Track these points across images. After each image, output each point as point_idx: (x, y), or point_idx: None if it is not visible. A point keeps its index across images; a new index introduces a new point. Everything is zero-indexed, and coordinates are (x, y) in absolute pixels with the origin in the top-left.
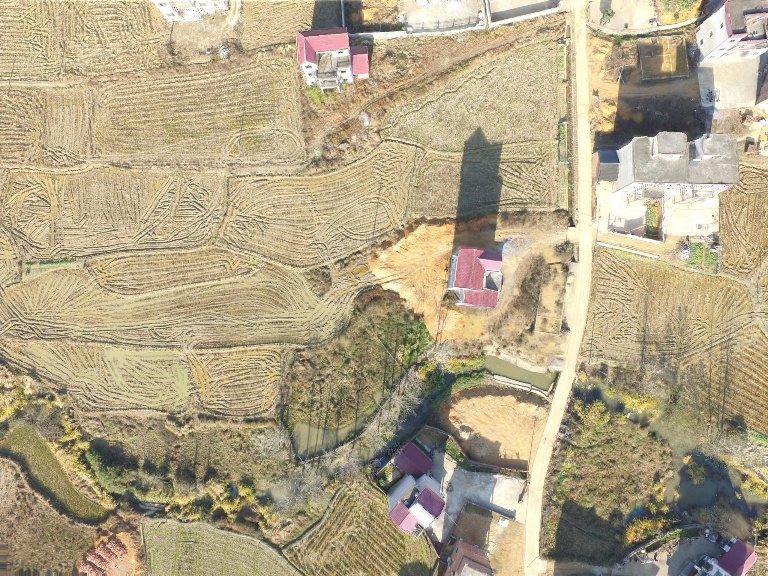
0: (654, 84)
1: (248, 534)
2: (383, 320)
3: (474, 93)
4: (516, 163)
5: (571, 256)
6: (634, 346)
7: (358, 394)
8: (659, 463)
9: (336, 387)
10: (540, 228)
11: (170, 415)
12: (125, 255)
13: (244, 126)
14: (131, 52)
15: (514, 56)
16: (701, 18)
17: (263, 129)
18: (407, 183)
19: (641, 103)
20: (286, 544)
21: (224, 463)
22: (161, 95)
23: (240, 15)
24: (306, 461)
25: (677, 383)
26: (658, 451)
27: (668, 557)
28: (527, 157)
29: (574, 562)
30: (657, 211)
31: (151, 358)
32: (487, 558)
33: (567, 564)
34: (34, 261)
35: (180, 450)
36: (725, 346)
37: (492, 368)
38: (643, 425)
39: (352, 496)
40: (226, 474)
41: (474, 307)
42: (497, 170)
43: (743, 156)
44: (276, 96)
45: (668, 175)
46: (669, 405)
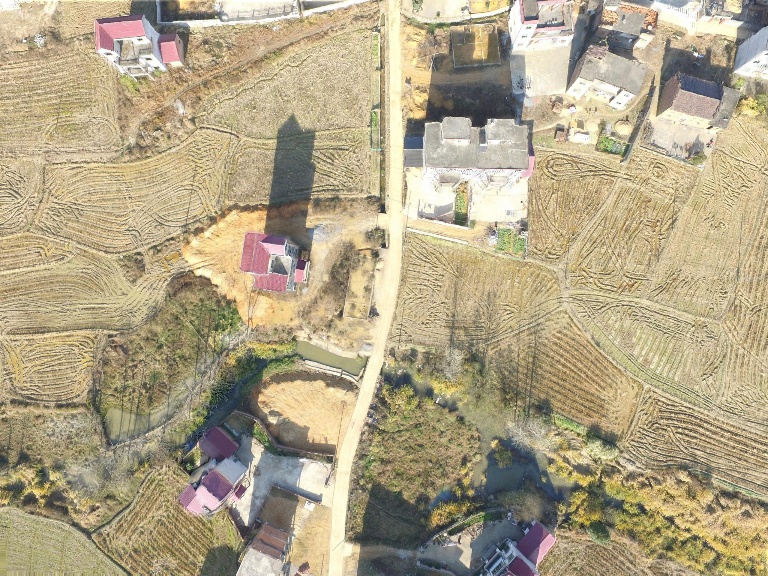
0: (466, 72)
1: (58, 518)
2: (196, 306)
3: (289, 81)
4: (329, 150)
5: (382, 242)
6: (443, 331)
7: (169, 379)
8: (467, 447)
9: (149, 372)
10: (351, 214)
11: None
12: None
13: (61, 114)
14: None
15: (329, 44)
16: None
17: (80, 117)
18: (221, 170)
19: (453, 90)
20: (96, 528)
21: (37, 448)
22: None
23: (58, 4)
24: (116, 446)
25: (485, 368)
26: (466, 435)
27: (472, 540)
28: (340, 144)
29: (379, 545)
30: (466, 197)
31: None
32: (287, 541)
33: (373, 547)
34: None
35: None
36: (533, 331)
37: (304, 353)
38: (451, 410)
39: (161, 480)
40: (39, 459)
41: (280, 292)
42: (310, 157)
43: (553, 143)
44: (93, 84)
45: (458, 160)
46: (477, 390)
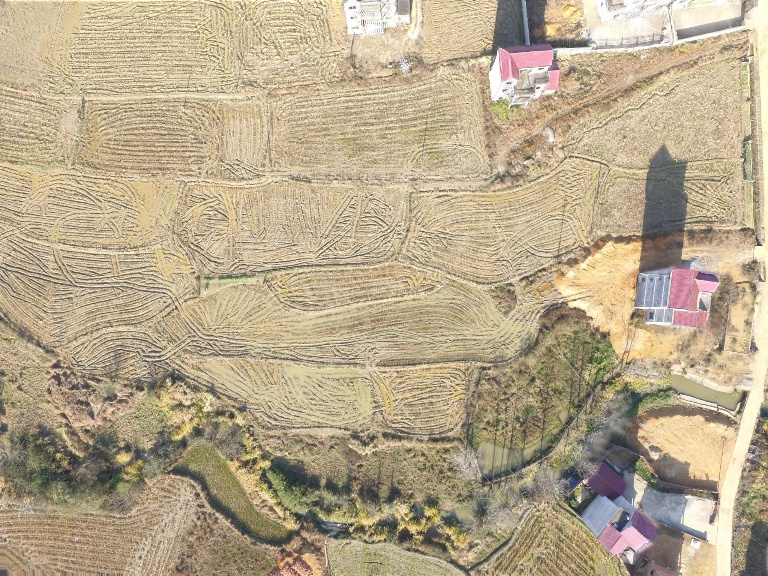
0: None
1: (435, 555)
2: (569, 338)
3: (658, 110)
4: (701, 181)
5: (757, 275)
6: None
7: (544, 413)
8: None
9: (521, 406)
10: (727, 247)
11: (354, 434)
12: (305, 270)
13: (426, 141)
14: (310, 65)
15: (697, 73)
16: None
17: (445, 144)
18: (592, 200)
19: None
20: (473, 566)
21: (408, 483)
22: (341, 108)
23: (421, 29)
24: (493, 481)
25: None
26: None
27: None
28: (712, 175)
29: None
30: None
31: (333, 375)
32: None
33: None
34: (212, 276)
35: (363, 469)
36: None
37: (678, 387)
38: None
39: (540, 517)
40: (410, 494)
41: (666, 326)
42: (682, 188)
43: None
44: (458, 111)
45: None
46: None
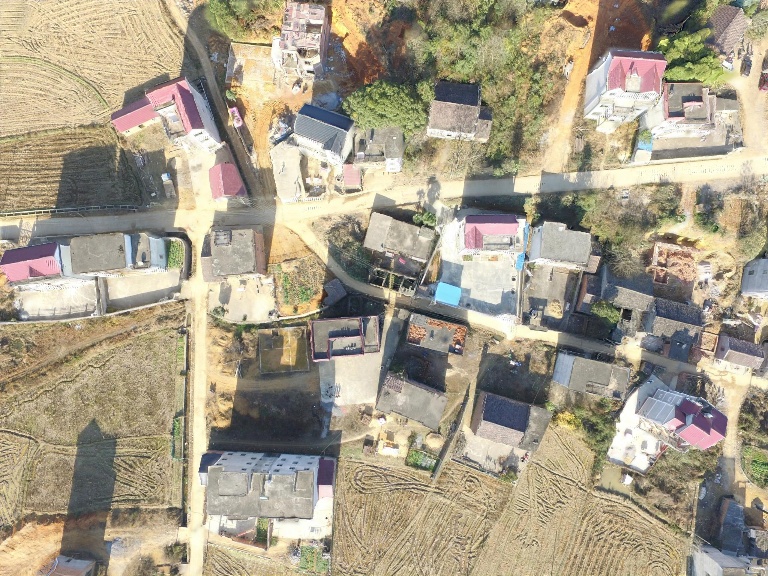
0: (273, 378)
1: None
2: None
3: (91, 383)
4: (131, 457)
5: (183, 556)
6: None
7: None
8: None
9: None
10: (151, 527)
11: None
12: None
13: None
14: None
15: (133, 344)
16: (324, 309)
17: None
18: (19, 476)
19: (259, 398)
20: None
21: None
22: None
23: None
24: None
25: None
26: None
27: None
28: (142, 451)
29: None
30: None
31: None
32: None
33: None
34: None
35: None
36: None
37: None
38: None
39: None
40: None
41: None
42: (111, 464)
43: (361, 455)
44: None
45: (240, 508)
46: None
